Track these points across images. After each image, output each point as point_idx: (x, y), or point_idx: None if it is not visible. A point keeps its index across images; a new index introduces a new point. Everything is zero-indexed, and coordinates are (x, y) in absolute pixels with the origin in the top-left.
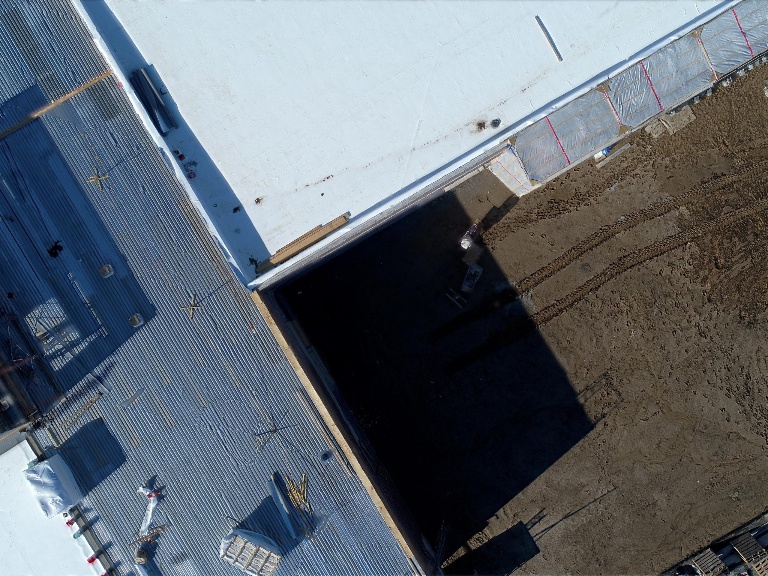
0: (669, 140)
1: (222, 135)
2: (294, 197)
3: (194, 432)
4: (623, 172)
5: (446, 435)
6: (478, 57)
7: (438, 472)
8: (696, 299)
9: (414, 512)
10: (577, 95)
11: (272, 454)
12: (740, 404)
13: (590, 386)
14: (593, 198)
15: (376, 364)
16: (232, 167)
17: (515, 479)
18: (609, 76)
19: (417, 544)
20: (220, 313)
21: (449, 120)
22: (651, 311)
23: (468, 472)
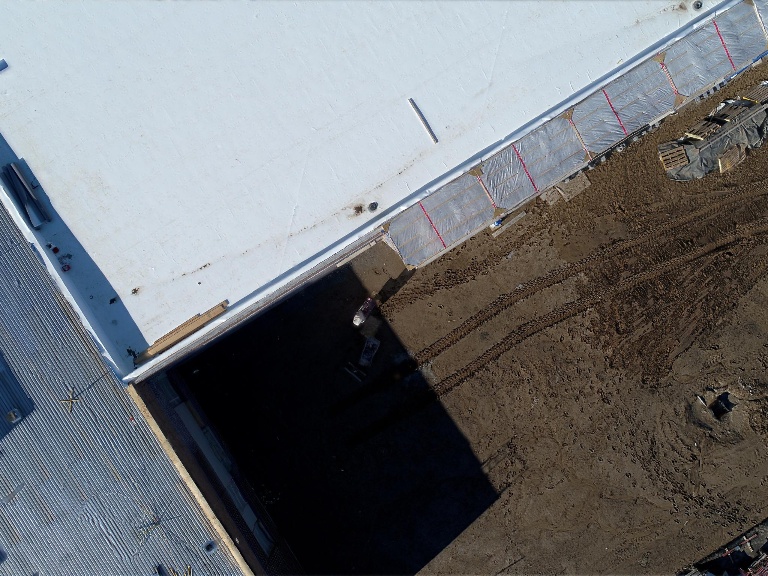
0: (565, 207)
1: (96, 227)
2: (171, 287)
3: (76, 526)
4: (519, 240)
5: (349, 509)
6: (352, 141)
7: (343, 547)
8: (598, 365)
9: None
10: (450, 179)
11: (156, 546)
12: (646, 469)
13: (494, 455)
14: (490, 267)
15: (276, 440)
16: (107, 258)
17: (421, 552)
18: (482, 159)
19: None
20: (99, 405)
21: (325, 205)
22: (553, 378)
23: (373, 546)
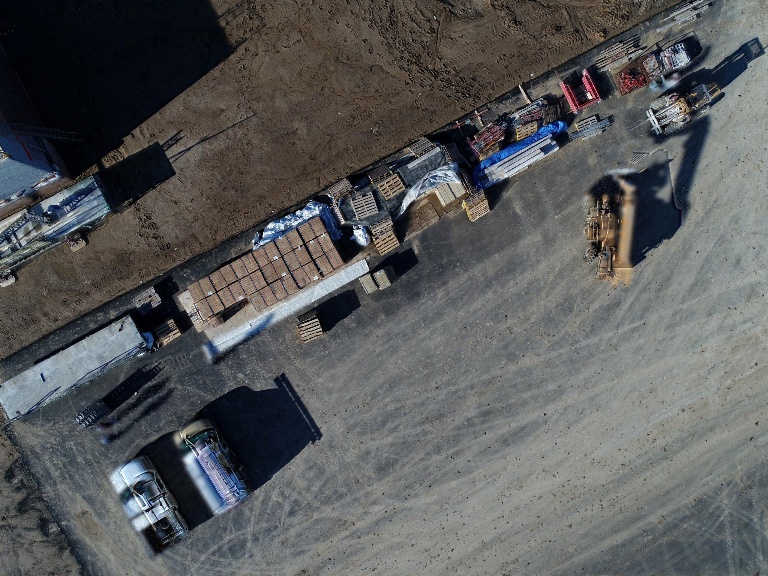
0: None
1: None
2: None
3: None
4: None
5: (83, 49)
6: None
7: (74, 86)
8: None
9: (47, 123)
10: None
11: None
12: (383, 36)
13: (232, 9)
14: None
15: None
16: None
17: (152, 98)
18: None
19: (6, 108)
20: None
21: None
22: None
23: (105, 88)
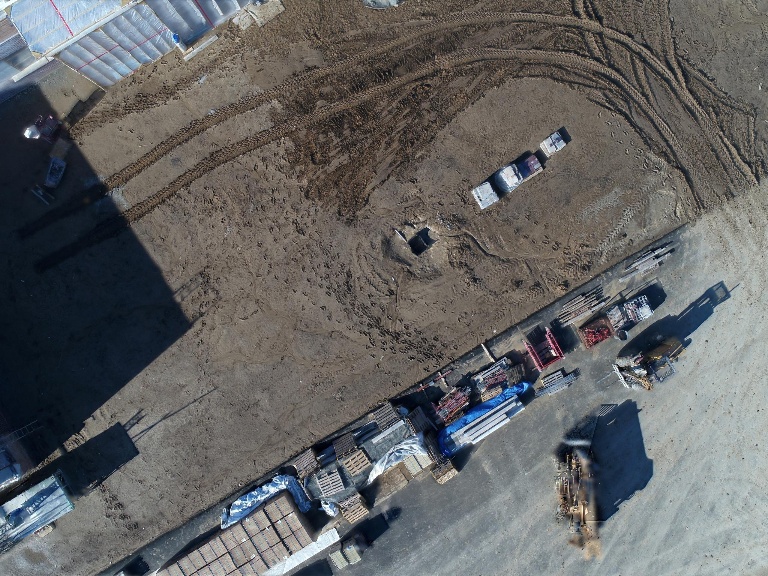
0: (258, 32)
1: None
2: None
3: None
4: (212, 65)
5: (38, 335)
6: None
7: (31, 373)
8: (293, 195)
9: (6, 413)
10: None
11: None
12: (341, 302)
13: (186, 284)
14: (182, 92)
15: None
16: None
17: (111, 379)
18: None
19: None
20: None
21: None
22: (246, 207)
23: (62, 372)
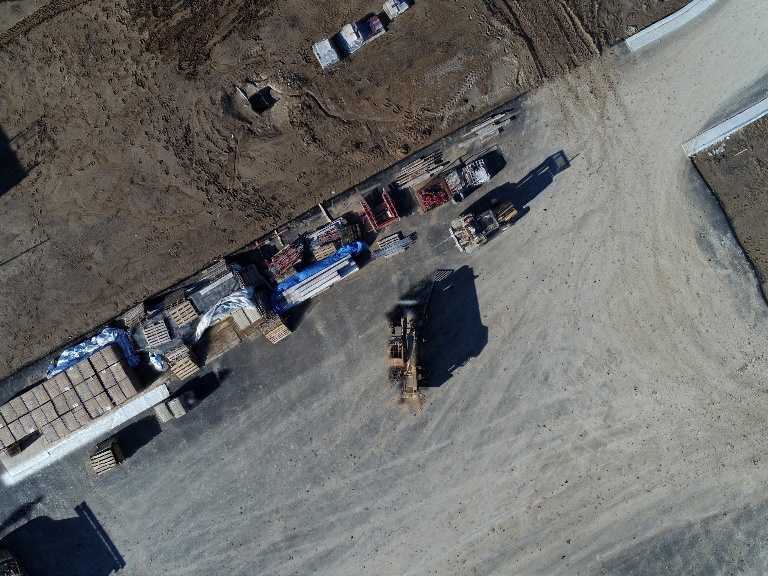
0: None
1: None
2: None
3: None
4: None
5: None
6: None
7: None
8: (134, 47)
9: None
10: None
11: None
12: (179, 157)
13: (23, 132)
14: None
15: None
16: None
17: None
18: None
19: None
20: None
21: None
22: (85, 57)
23: None
